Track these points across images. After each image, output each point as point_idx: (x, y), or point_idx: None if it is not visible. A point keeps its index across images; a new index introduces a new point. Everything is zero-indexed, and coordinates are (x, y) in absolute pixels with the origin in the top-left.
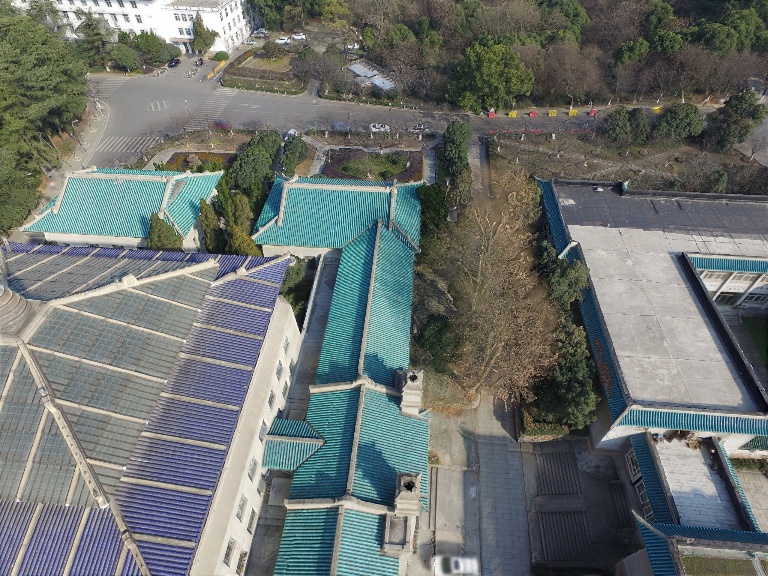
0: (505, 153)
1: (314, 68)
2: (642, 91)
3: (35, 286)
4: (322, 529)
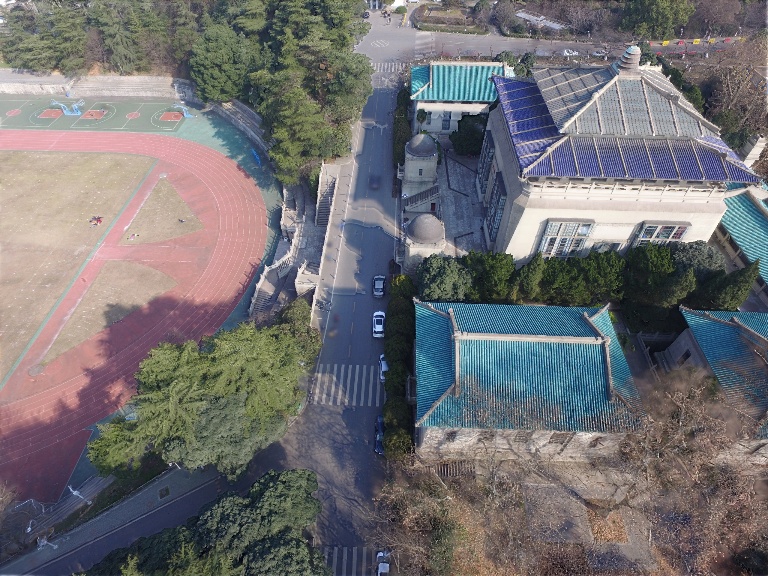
0: (676, 66)
1: (500, 13)
2: (759, 25)
3: None
4: (740, 202)
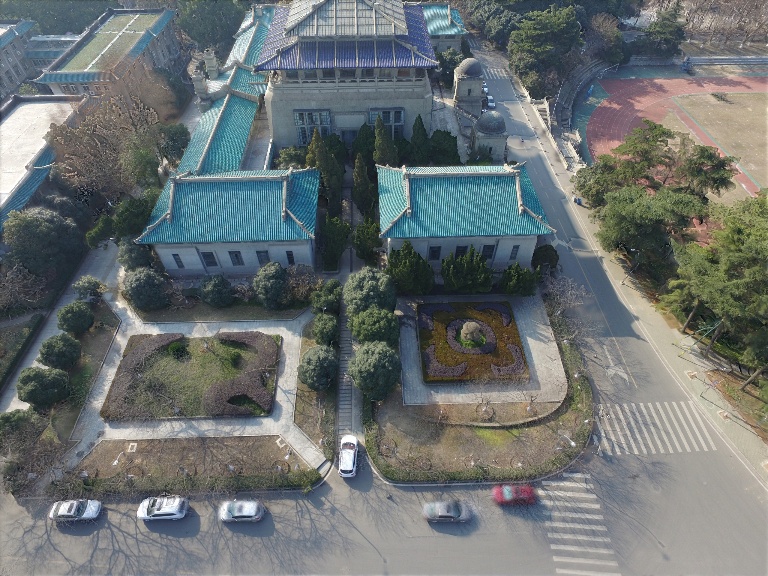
0: None
1: None
2: None
3: (355, 4)
4: None
